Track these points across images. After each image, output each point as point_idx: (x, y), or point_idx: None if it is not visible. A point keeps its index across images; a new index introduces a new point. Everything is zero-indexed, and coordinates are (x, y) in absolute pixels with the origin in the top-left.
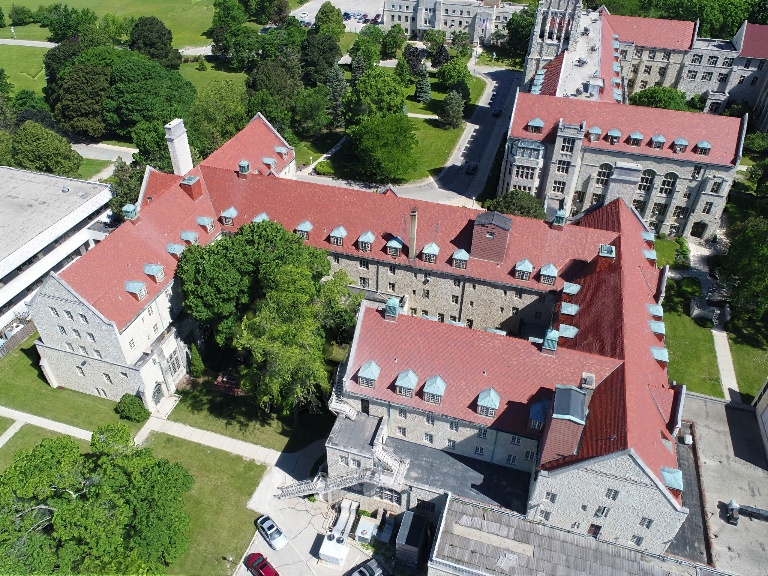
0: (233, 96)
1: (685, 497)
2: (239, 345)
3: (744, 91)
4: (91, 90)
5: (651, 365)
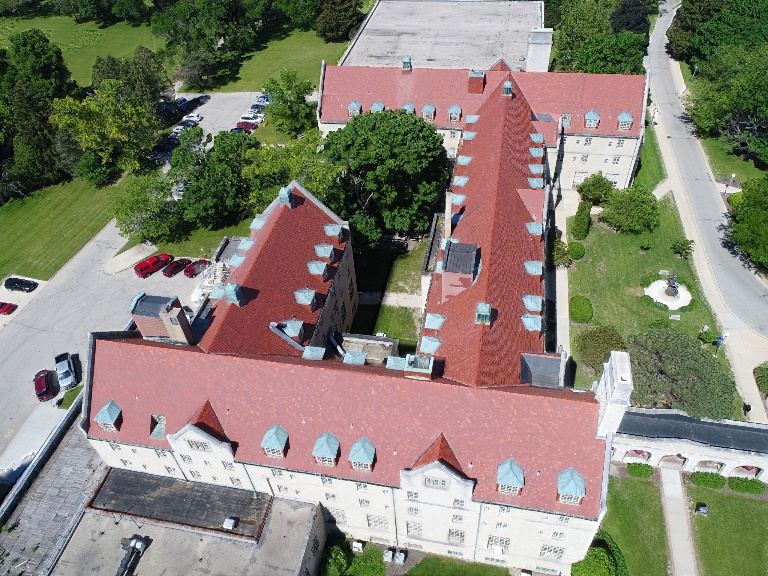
0: (760, 66)
1: (162, 504)
2: (266, 148)
3: None
4: (706, 6)
5: (249, 420)
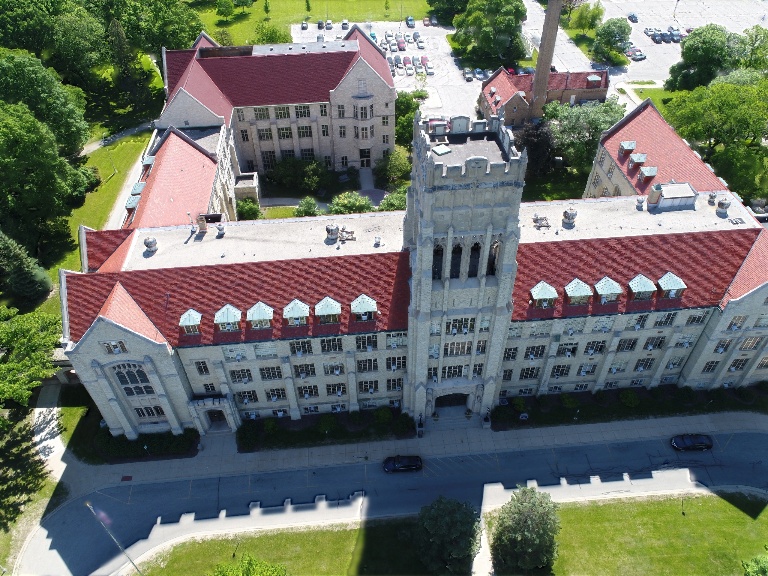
0: None
1: None
2: None
3: (238, 160)
4: None
5: None
